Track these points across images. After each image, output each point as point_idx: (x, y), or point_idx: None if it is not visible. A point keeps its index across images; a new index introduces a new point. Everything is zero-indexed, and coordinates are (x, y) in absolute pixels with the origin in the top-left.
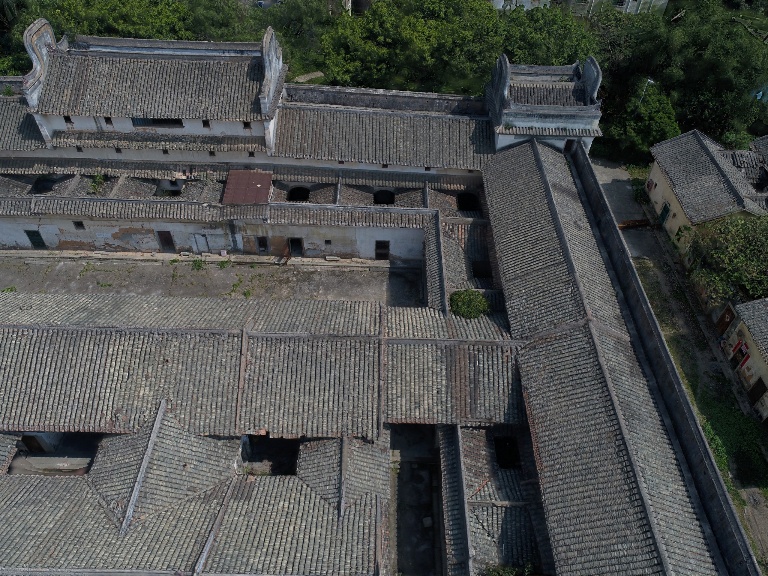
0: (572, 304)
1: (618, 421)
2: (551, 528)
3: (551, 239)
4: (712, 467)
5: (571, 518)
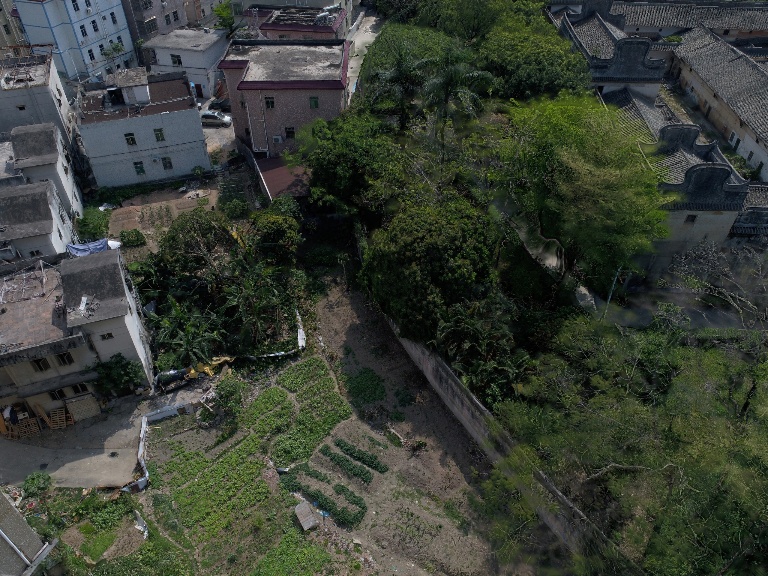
0: (687, 8)
1: (735, 8)
2: (766, 29)
3: (652, 8)
4: (740, 2)
5: (764, 24)
